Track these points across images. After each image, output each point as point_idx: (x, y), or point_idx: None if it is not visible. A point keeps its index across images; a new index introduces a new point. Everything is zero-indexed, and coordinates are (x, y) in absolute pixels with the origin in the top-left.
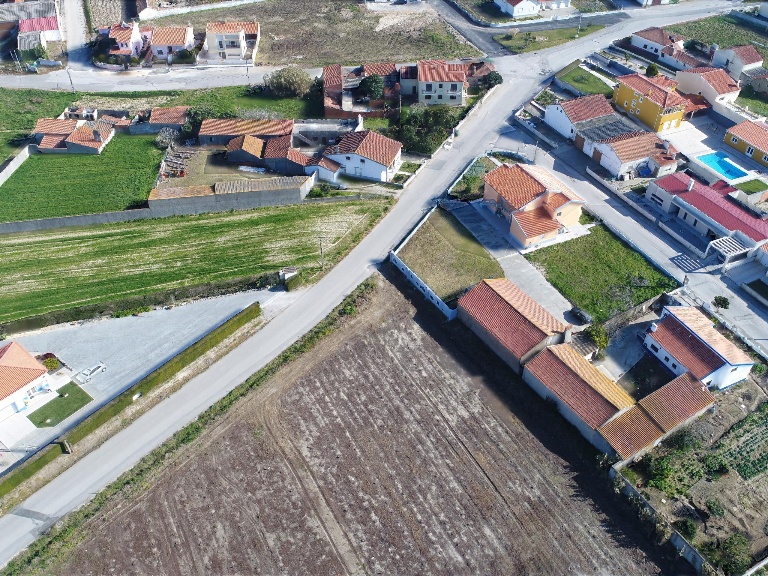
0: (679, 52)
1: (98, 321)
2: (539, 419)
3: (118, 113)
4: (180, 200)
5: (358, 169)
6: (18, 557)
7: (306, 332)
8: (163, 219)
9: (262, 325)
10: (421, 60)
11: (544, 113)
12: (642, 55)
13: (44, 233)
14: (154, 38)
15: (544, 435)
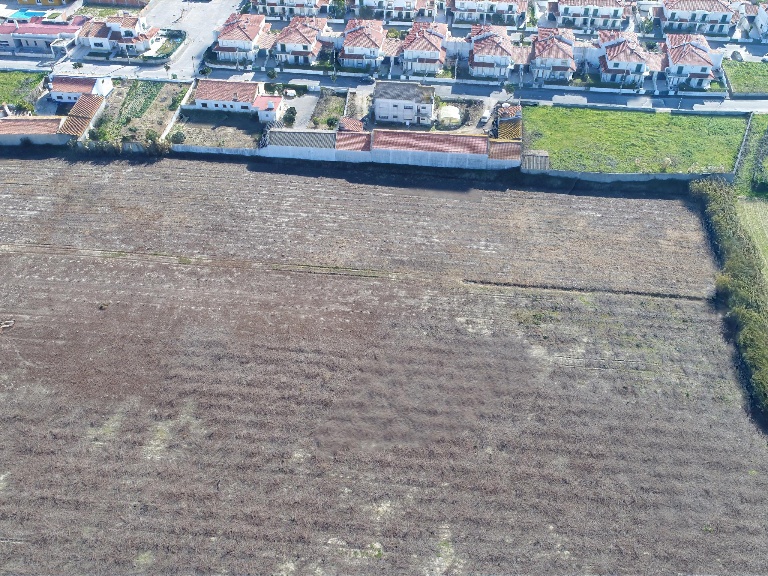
0: None
1: None
2: (26, 154)
3: None
4: None
5: None
6: None
7: None
8: None
9: None
10: None
11: None
12: None
13: None
14: None
15: (35, 157)
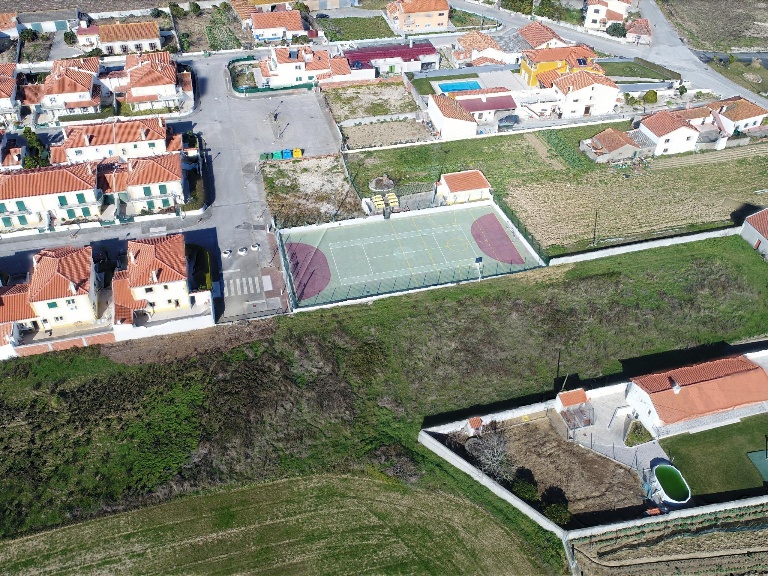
0: (689, 108)
1: None
2: None
3: None
4: None
5: None
6: None
7: None
8: None
9: None
10: None
11: None
12: None
13: None
14: None
15: None
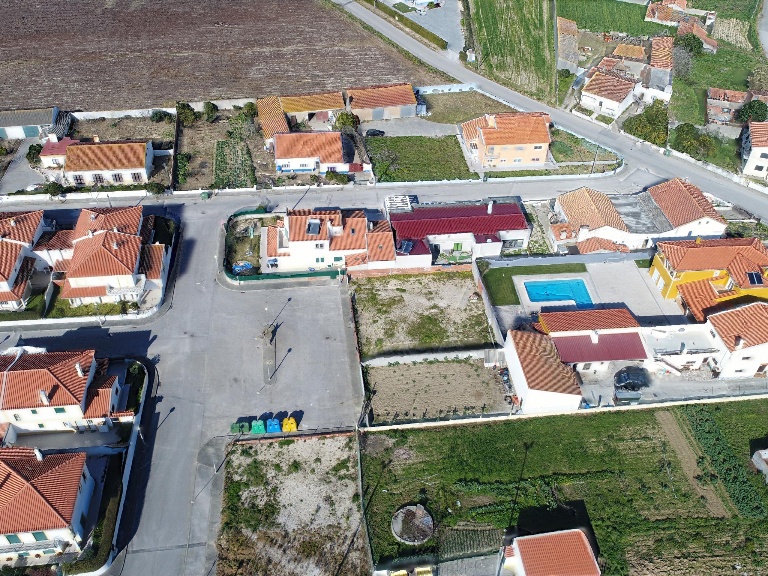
0: None
1: None
2: None
3: None
4: None
5: None
6: (332, 1)
7: (421, 58)
8: None
9: None
10: None
11: None
12: None
13: (550, 8)
14: None
15: None
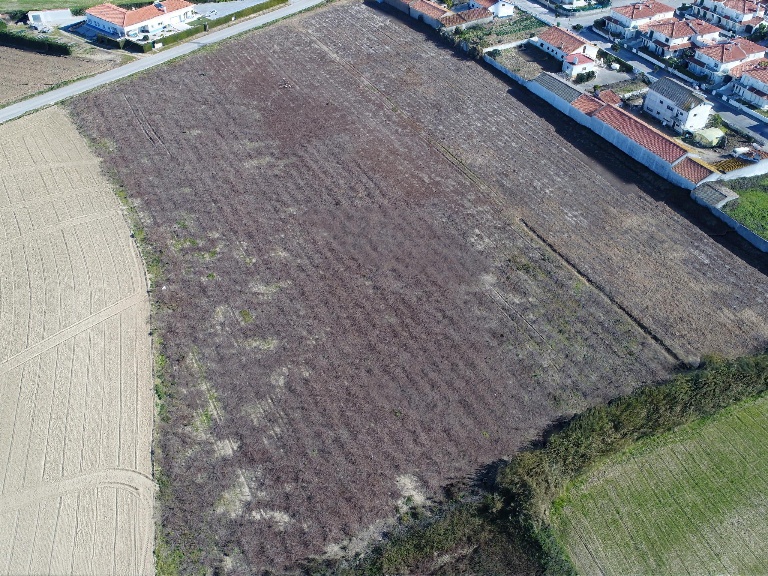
0: None
1: (209, 3)
2: (415, 25)
3: None
4: None
5: None
6: (195, 50)
7: (310, 6)
8: None
9: None
10: None
11: None
12: None
13: None
14: None
15: None
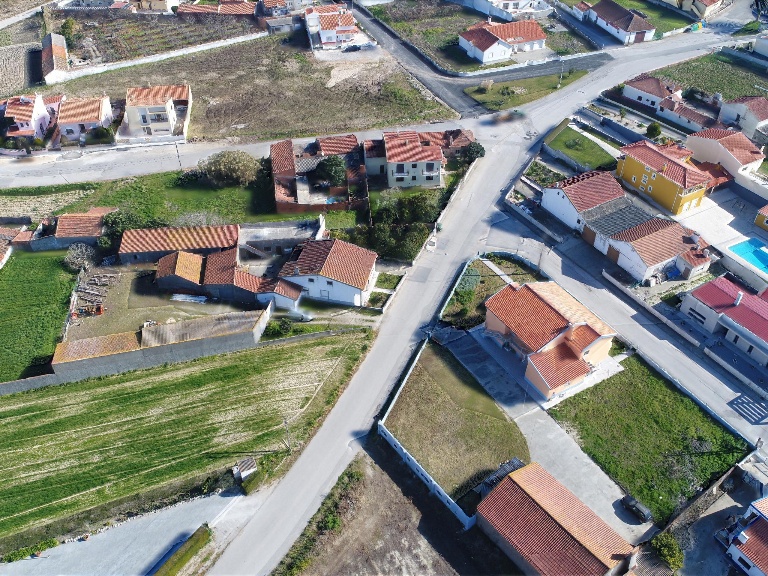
0: (681, 106)
1: None
2: None
3: (17, 220)
4: (95, 360)
5: (324, 292)
6: None
7: (275, 566)
8: (74, 384)
9: (213, 558)
10: (387, 132)
11: (539, 193)
12: (637, 108)
13: None
14: (61, 115)
15: None
